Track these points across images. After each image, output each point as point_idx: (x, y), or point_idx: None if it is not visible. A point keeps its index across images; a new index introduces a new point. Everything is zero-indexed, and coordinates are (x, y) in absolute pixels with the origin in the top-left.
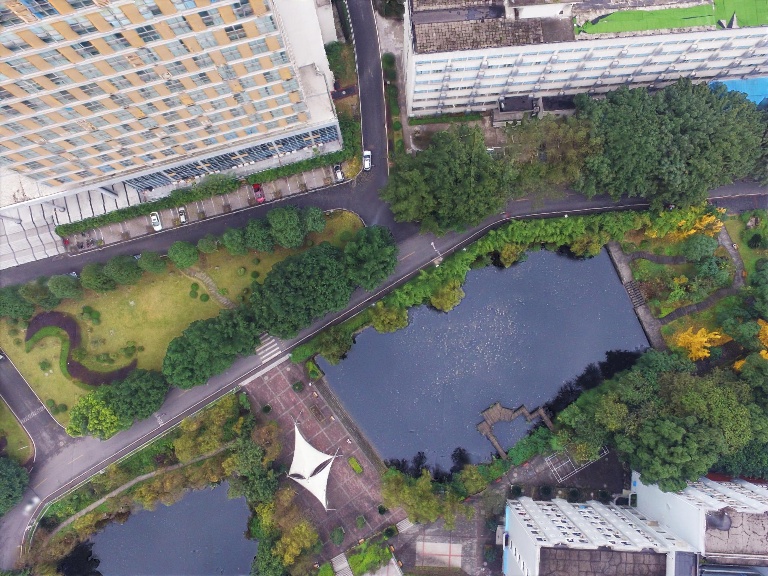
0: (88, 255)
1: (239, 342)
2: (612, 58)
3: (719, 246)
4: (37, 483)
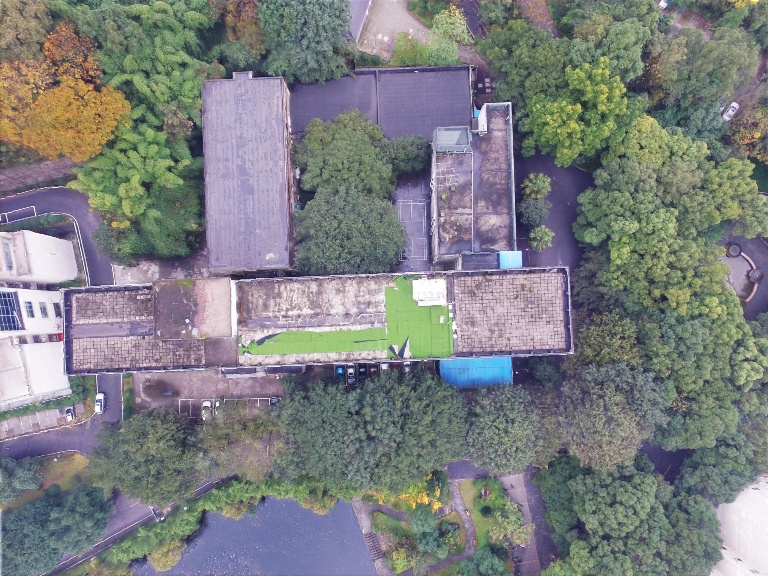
0: None
1: None
2: None
3: (452, 511)
4: None
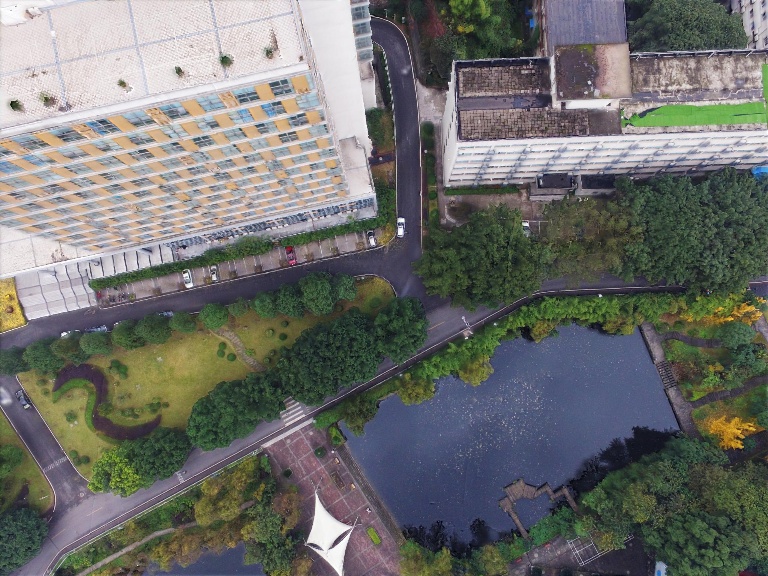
0: (119, 309)
1: (264, 407)
2: (657, 147)
3: (756, 332)
4: (55, 533)
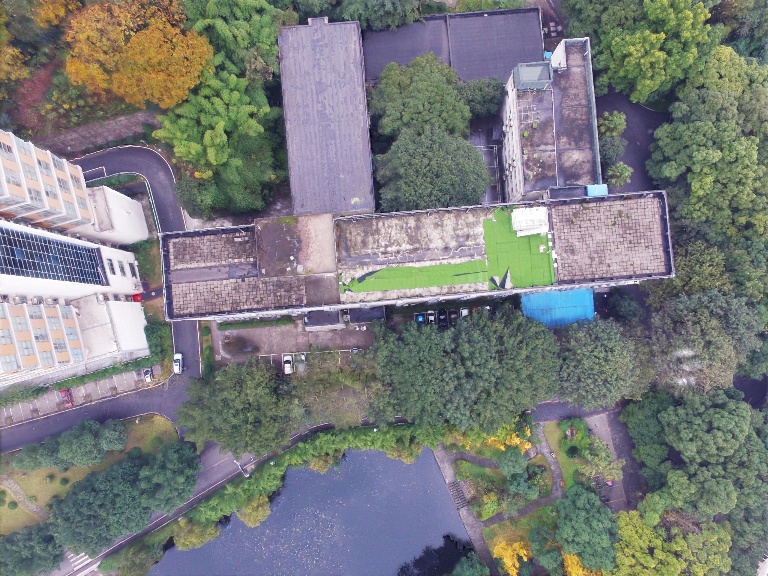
0: None
1: (37, 564)
2: None
3: (537, 454)
4: None
